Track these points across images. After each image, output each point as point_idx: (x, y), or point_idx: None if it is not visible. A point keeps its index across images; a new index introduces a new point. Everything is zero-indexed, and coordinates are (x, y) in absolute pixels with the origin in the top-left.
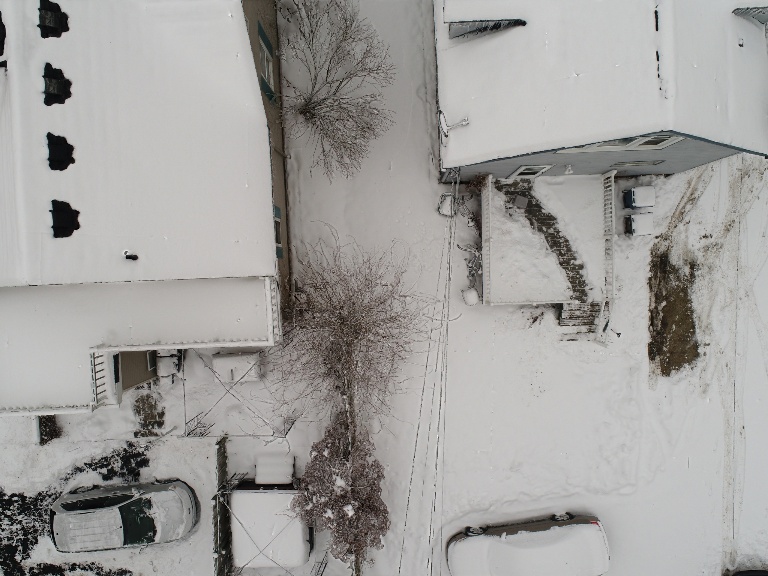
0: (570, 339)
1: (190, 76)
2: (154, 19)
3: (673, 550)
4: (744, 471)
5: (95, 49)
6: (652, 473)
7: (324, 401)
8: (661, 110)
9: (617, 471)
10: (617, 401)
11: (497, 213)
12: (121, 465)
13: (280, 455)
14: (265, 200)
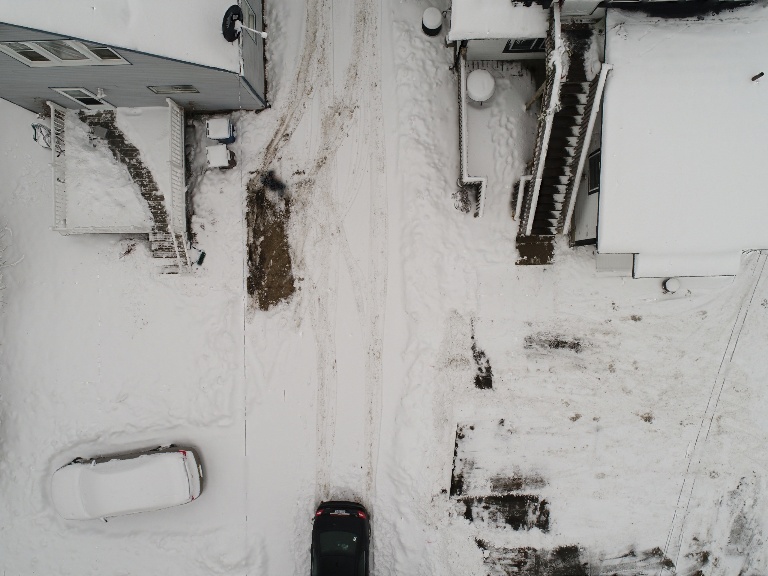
0: (171, 272)
1: None
2: None
3: (270, 482)
4: (336, 404)
5: None
6: (247, 405)
7: None
8: None
9: (212, 402)
10: (214, 334)
11: (76, 143)
12: None
13: None
14: None
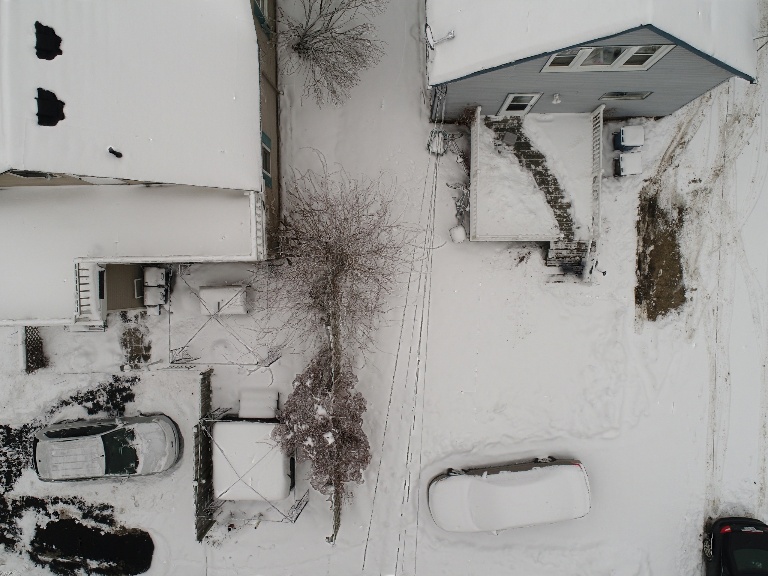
0: (557, 281)
1: None
2: None
3: (656, 496)
4: (729, 418)
5: None
6: (636, 417)
7: (308, 332)
8: (640, 4)
9: (601, 414)
10: (602, 344)
11: (486, 149)
12: (106, 399)
13: (264, 391)
14: (252, 115)
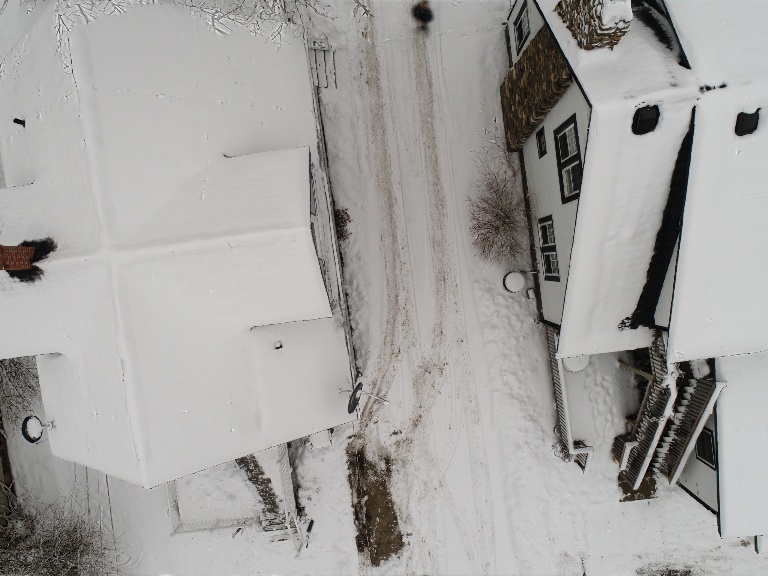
0: (281, 539)
1: None
2: None
3: None
4: None
5: None
6: None
7: None
8: (137, 471)
9: None
10: None
11: None
12: None
13: None
14: None
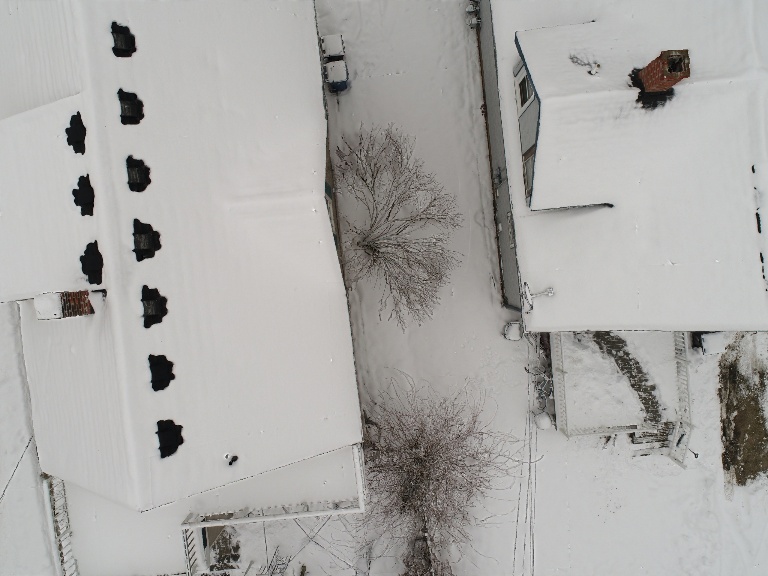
0: (643, 454)
1: (273, 264)
2: (237, 216)
3: None
4: None
5: (186, 260)
6: None
7: (405, 538)
8: None
9: None
10: (695, 514)
11: (566, 341)
12: None
13: None
14: (348, 370)
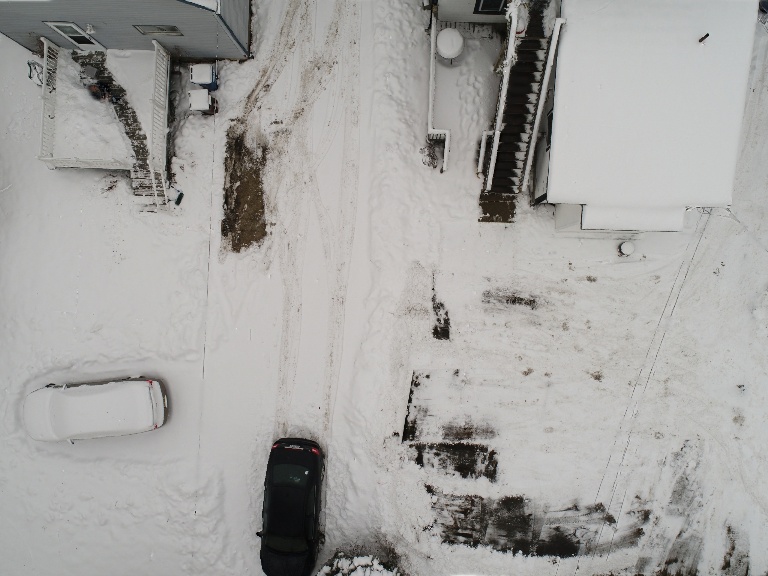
0: (150, 211)
1: None
2: None
3: (232, 417)
4: (298, 346)
5: None
6: (214, 341)
7: None
8: None
9: (180, 337)
10: (187, 271)
11: (67, 80)
12: None
13: None
14: None
